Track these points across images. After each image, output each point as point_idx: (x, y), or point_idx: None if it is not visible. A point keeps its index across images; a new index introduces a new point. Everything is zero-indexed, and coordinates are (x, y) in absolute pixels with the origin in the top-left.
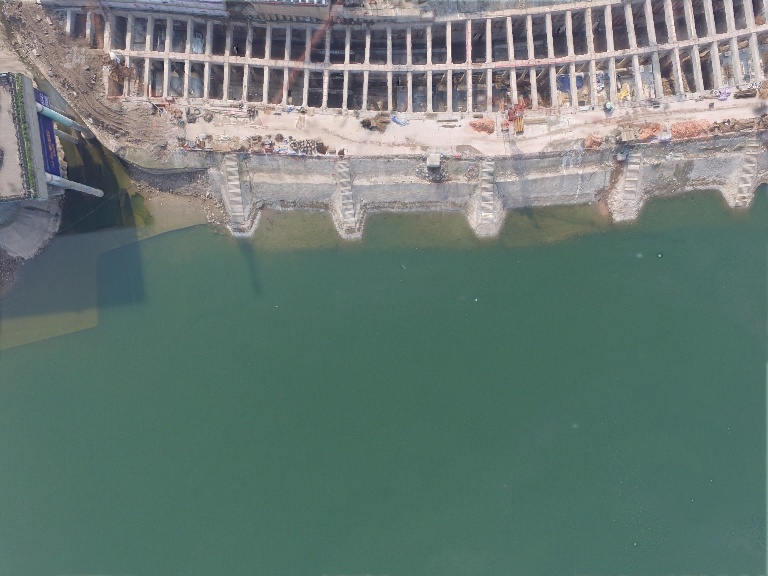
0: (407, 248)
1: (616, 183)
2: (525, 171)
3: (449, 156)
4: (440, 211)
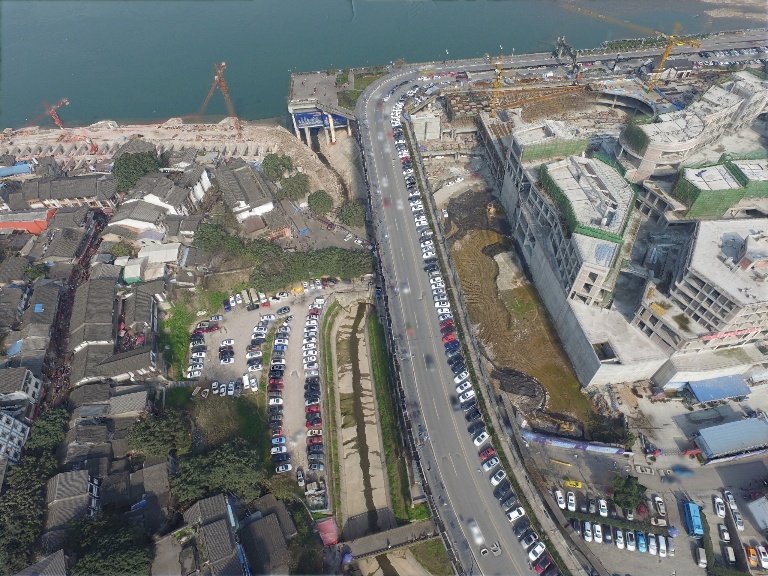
0: None
1: None
2: None
3: None
4: None
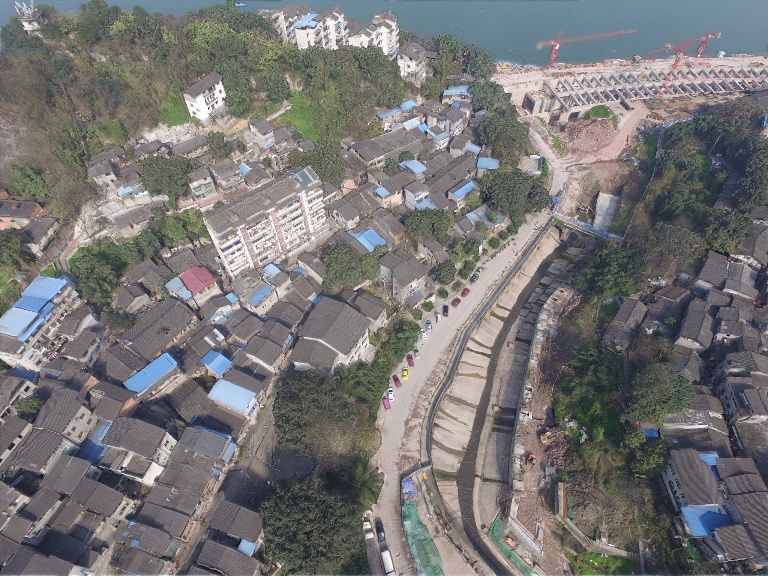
0: None
1: None
2: None
3: None
4: None
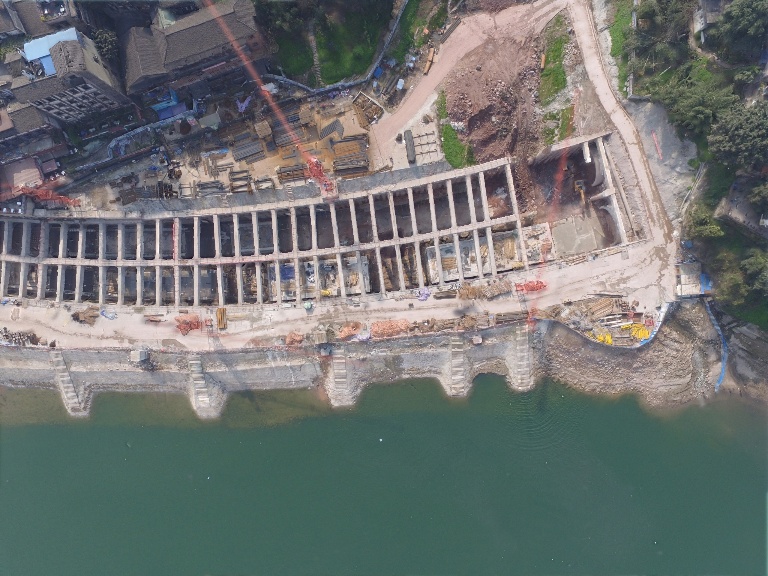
0: (134, 426)
1: (328, 373)
2: (234, 362)
3: (155, 349)
4: (164, 392)
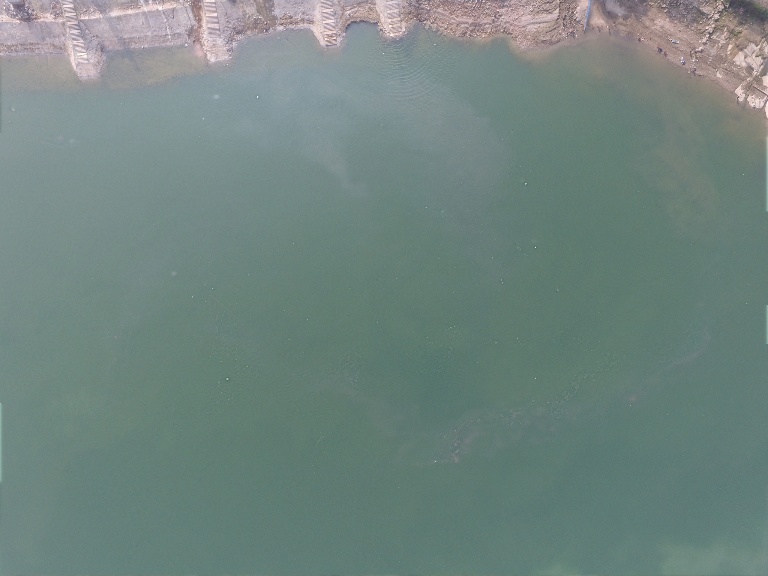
0: (18, 92)
1: (201, 21)
2: (107, 8)
3: None
4: (45, 54)
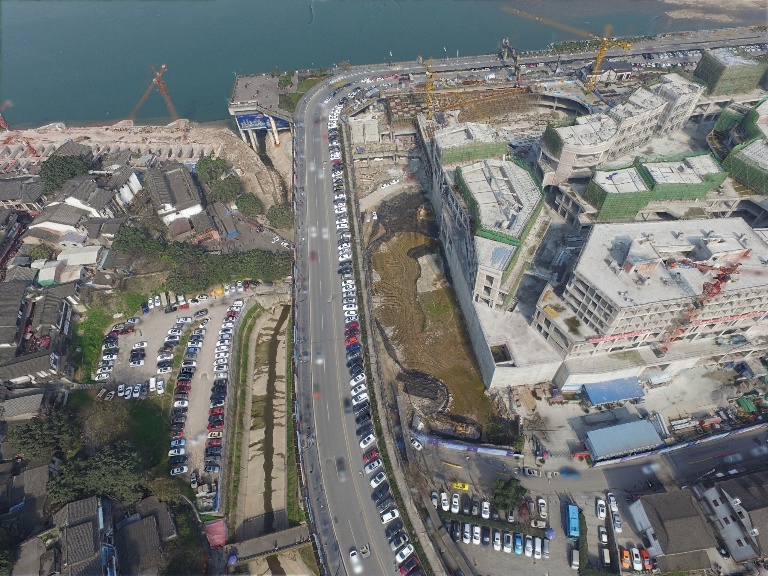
0: None
1: None
2: None
3: None
4: None
